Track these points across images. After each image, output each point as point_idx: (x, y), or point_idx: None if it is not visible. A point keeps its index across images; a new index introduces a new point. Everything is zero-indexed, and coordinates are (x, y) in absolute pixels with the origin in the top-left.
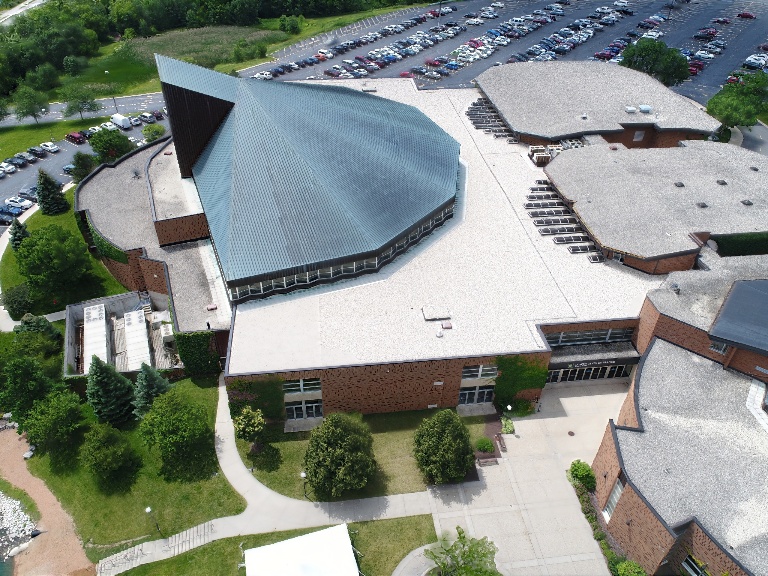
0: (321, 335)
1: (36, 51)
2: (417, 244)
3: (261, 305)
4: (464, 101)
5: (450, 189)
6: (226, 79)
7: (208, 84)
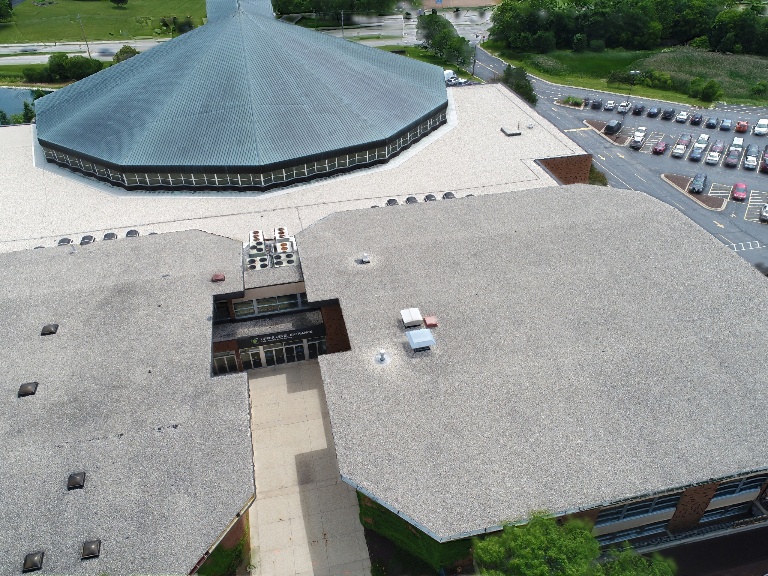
0: None
1: (563, 21)
2: (84, 176)
3: (35, 130)
4: None
5: (130, 160)
6: (232, 6)
7: (218, 4)
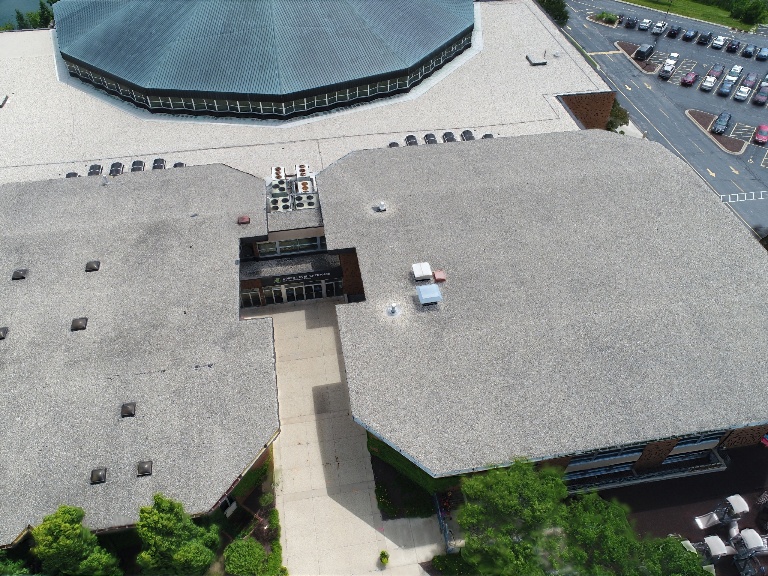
0: (4, 59)
1: None
2: (108, 93)
3: (55, 36)
4: (525, 134)
5: (153, 82)
6: None
7: None
